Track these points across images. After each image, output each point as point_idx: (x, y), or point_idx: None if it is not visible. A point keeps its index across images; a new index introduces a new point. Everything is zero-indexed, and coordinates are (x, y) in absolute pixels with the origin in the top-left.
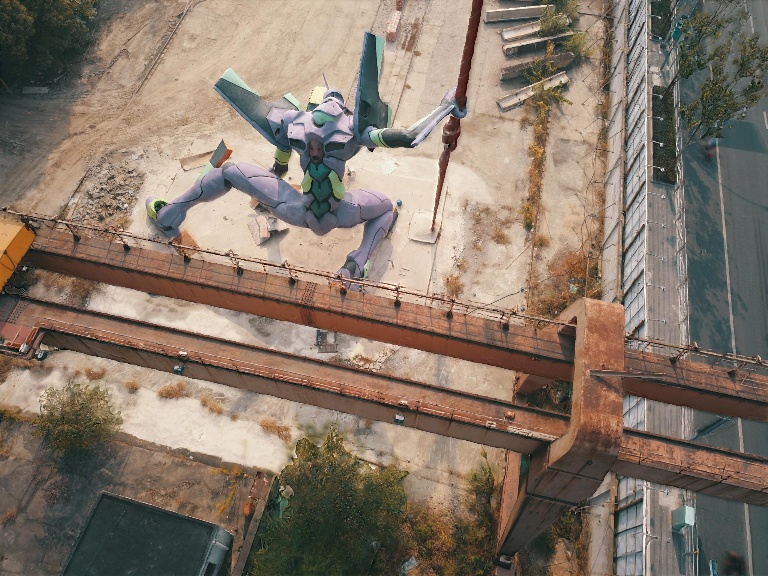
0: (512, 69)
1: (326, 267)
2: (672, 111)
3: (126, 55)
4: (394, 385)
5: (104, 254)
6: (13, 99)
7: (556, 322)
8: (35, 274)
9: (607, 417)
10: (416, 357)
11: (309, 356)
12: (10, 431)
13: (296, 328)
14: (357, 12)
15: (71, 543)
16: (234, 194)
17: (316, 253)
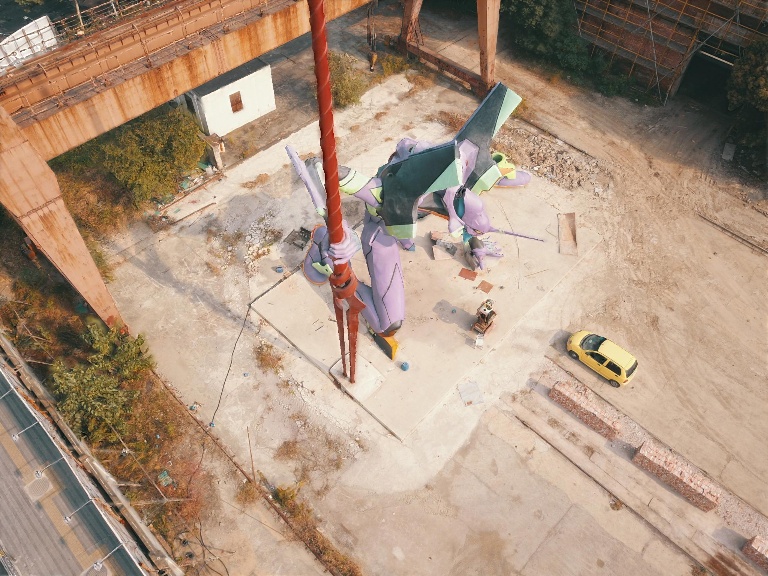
0: None
1: None
2: None
3: None
4: None
5: None
6: (720, 137)
7: (3, 80)
8: None
9: None
10: (231, 291)
11: (296, 223)
12: (370, 77)
13: None
14: None
15: (278, 85)
16: (506, 238)
17: None
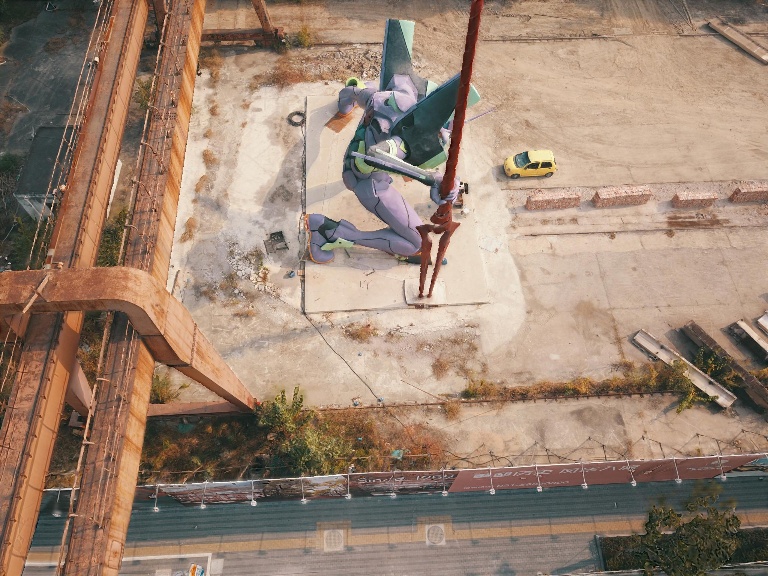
0: (698, 332)
1: (350, 222)
2: (746, 558)
3: (525, 20)
4: (86, 185)
5: (182, 4)
6: None
7: None
8: (287, 51)
9: (6, 291)
10: (277, 316)
11: (259, 235)
12: None
13: (283, 218)
14: (698, 163)
15: None
16: None
17: (362, 211)
